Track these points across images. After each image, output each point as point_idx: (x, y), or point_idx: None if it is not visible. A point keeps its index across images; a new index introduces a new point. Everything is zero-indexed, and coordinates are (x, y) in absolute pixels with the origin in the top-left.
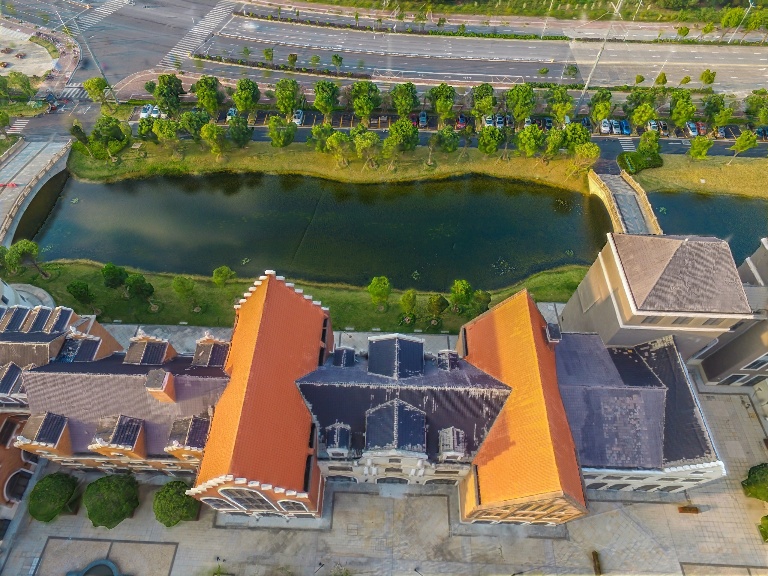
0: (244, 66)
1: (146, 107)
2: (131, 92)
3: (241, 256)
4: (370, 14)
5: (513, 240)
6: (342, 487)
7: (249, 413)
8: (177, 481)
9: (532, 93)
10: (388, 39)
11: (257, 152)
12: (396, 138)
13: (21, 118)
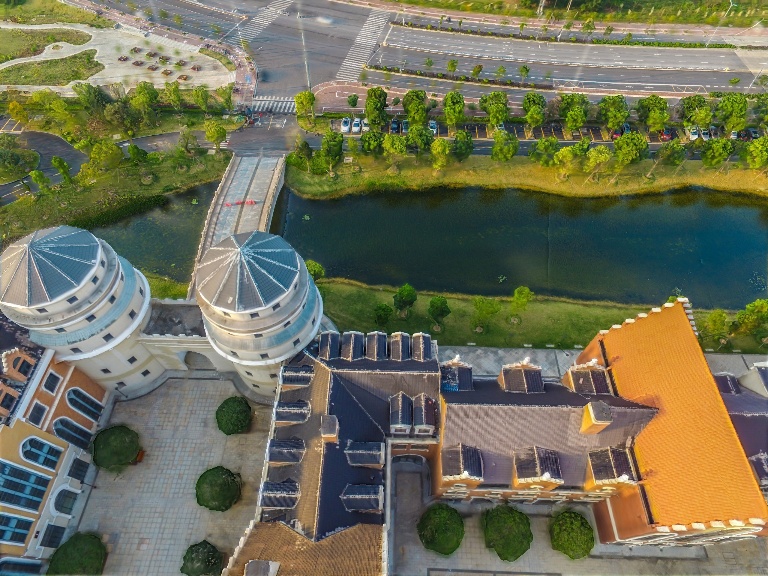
0: (423, 77)
1: (346, 120)
2: (321, 105)
3: (494, 273)
4: (526, 23)
5: (759, 255)
6: None
7: None
8: (570, 512)
9: None
10: (554, 48)
11: (472, 166)
12: (629, 152)
13: None
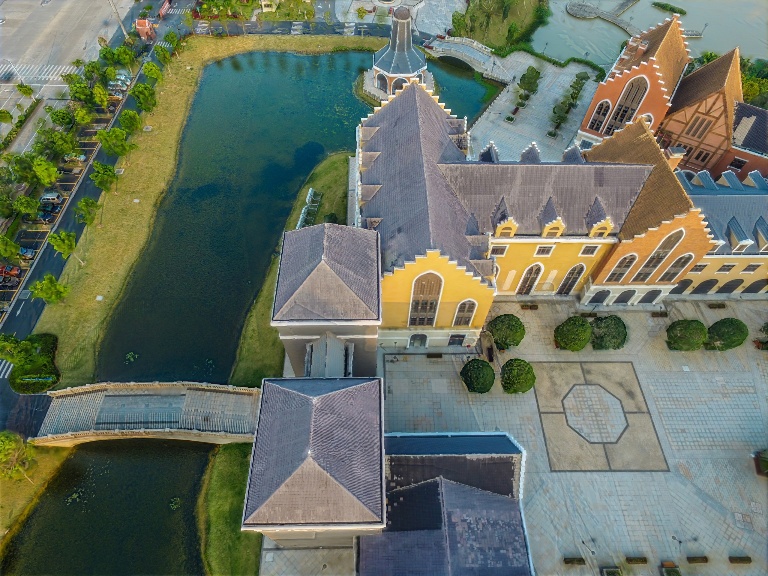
0: None
1: None
2: None
3: None
4: None
5: None
6: None
7: None
8: None
9: None
10: None
11: None
12: None
13: None
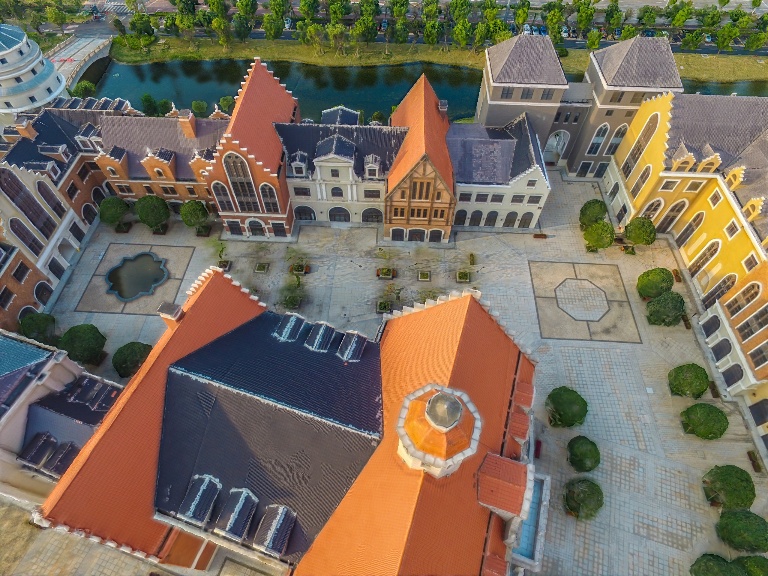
0: None
1: None
2: (157, 8)
3: None
4: None
5: None
6: (306, 223)
7: (242, 117)
8: None
9: (467, 1)
10: None
11: (254, 46)
12: (359, 29)
13: (72, 24)
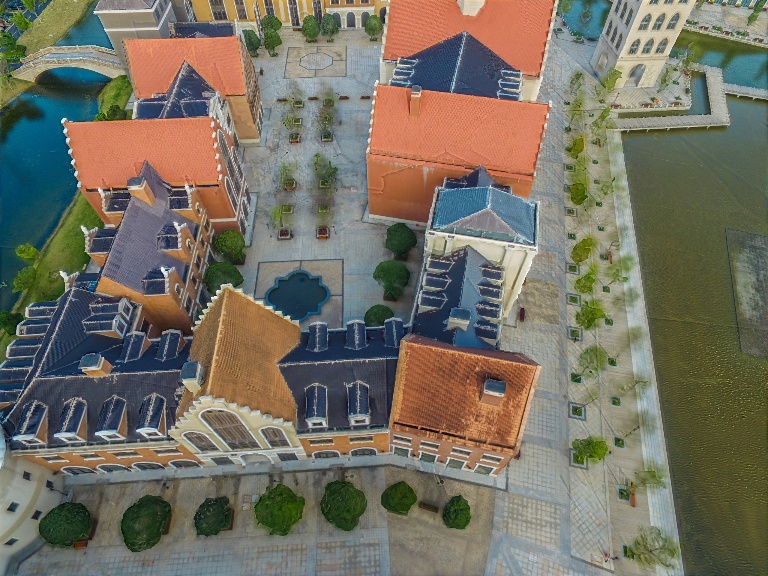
0: None
1: None
2: None
3: None
4: None
5: None
6: None
7: None
8: None
9: None
10: None
11: None
12: None
13: None
